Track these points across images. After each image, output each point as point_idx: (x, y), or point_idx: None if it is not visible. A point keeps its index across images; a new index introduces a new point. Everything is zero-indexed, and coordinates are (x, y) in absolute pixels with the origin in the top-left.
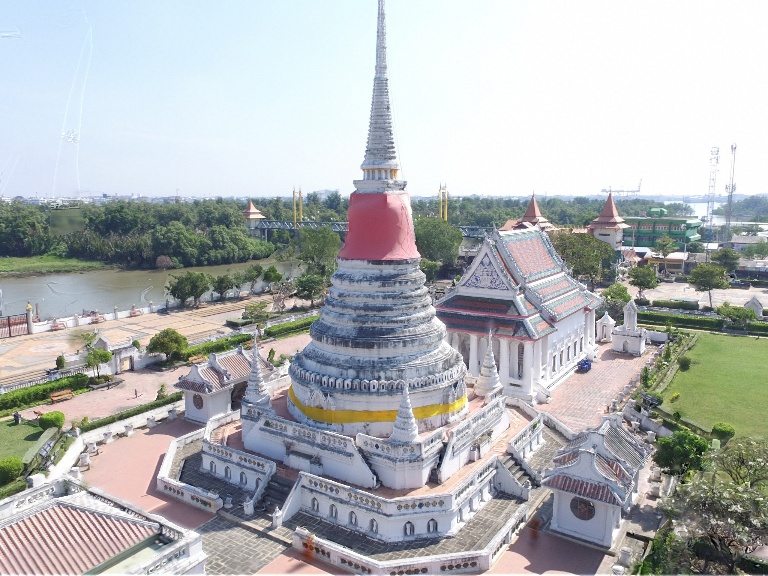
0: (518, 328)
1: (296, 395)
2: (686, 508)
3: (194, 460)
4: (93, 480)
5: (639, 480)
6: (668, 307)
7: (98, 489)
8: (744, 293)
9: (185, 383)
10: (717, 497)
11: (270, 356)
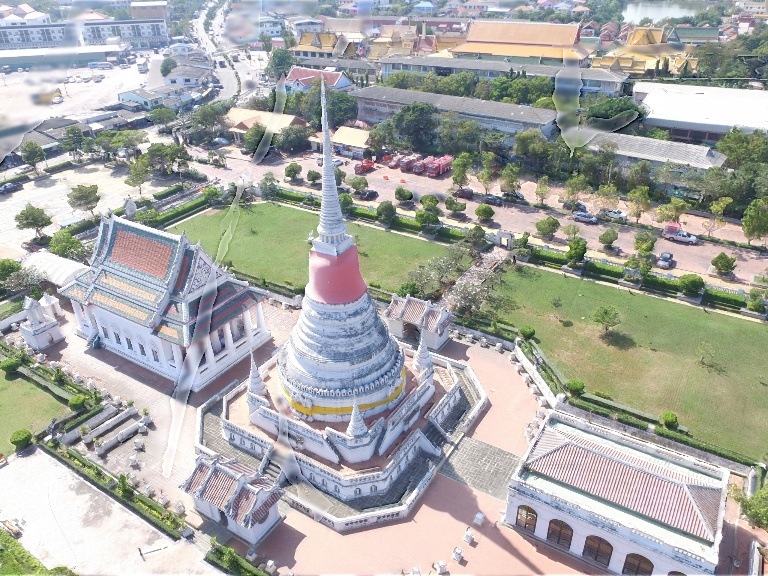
0: (253, 296)
1: (371, 402)
2: (469, 301)
3: (364, 503)
4: (391, 568)
5: (385, 319)
6: (73, 234)
7: (524, 457)
8: (39, 194)
9: (258, 514)
10: (475, 290)
11: (125, 483)
